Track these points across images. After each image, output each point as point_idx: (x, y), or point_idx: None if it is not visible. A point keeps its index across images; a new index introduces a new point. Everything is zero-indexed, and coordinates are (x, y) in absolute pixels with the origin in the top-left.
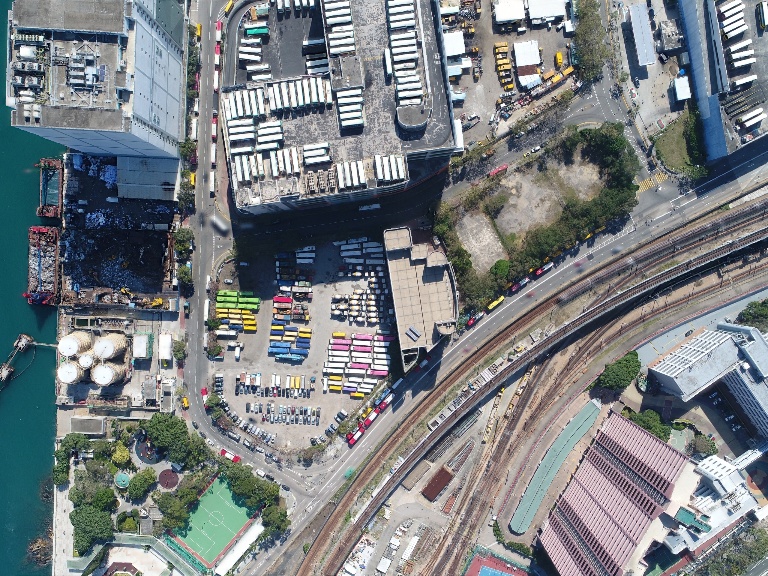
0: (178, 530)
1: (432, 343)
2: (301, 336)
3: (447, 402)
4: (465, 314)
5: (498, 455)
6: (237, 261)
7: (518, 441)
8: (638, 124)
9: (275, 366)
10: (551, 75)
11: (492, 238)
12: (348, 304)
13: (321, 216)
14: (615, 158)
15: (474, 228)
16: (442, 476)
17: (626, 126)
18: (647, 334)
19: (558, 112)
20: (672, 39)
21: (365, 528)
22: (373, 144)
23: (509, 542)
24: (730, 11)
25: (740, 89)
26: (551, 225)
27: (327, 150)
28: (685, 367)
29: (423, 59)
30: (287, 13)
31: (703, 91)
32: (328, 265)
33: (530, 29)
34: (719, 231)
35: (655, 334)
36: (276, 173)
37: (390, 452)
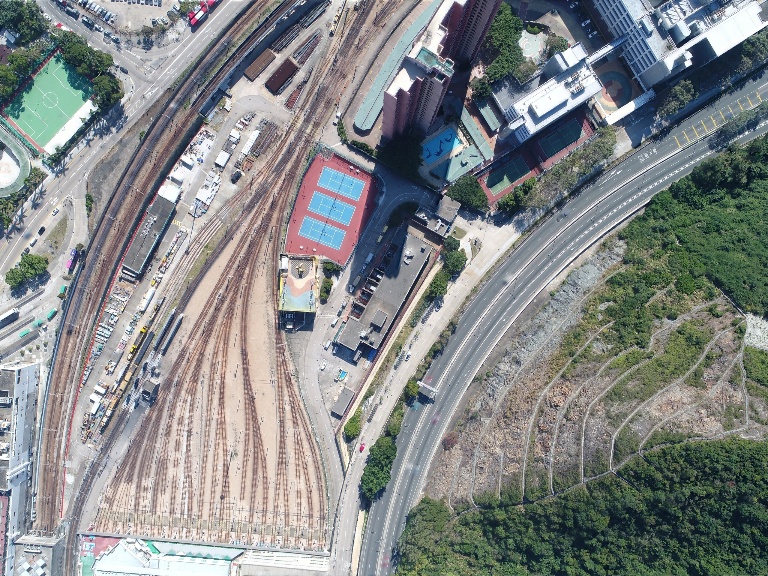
0: (10, 110)
1: None
2: None
3: None
4: None
5: (346, 50)
6: None
7: (367, 36)
8: None
9: None
10: None
11: None
12: None
13: None
14: None
15: None
16: (286, 66)
17: None
18: None
19: None
20: None
21: (204, 118)
22: None
23: (352, 140)
24: None
25: None
26: None
27: None
28: None
29: None
30: None
31: None
32: None
33: None
34: None
35: None
36: None
37: (234, 39)
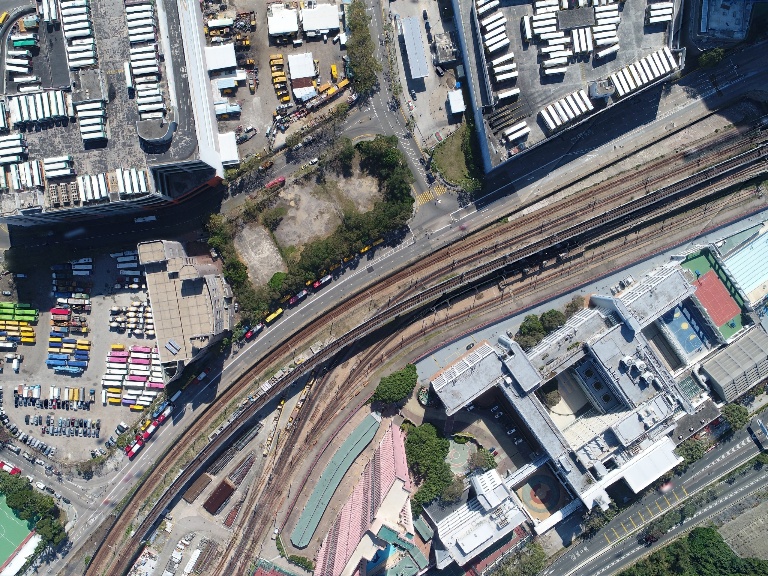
0: None
1: (192, 356)
2: (79, 348)
3: (228, 415)
4: (244, 326)
5: (280, 468)
6: (15, 273)
7: (300, 454)
8: (416, 137)
9: (55, 378)
10: (326, 87)
11: (271, 250)
12: (127, 316)
13: (99, 228)
14: (390, 171)
15: (253, 240)
16: (223, 489)
17: (404, 139)
18: (428, 347)
19: (336, 124)
20: (446, 52)
21: (146, 541)
22: (118, 157)
23: (290, 556)
24: (491, 25)
25: (506, 102)
26: (327, 238)
27: (71, 163)
28: (448, 381)
29: (166, 72)
30: (57, 25)
31: (475, 104)
32: (107, 277)
33: (306, 41)
34: (498, 244)
35: (436, 347)
36: (16, 186)
37: (171, 465)
